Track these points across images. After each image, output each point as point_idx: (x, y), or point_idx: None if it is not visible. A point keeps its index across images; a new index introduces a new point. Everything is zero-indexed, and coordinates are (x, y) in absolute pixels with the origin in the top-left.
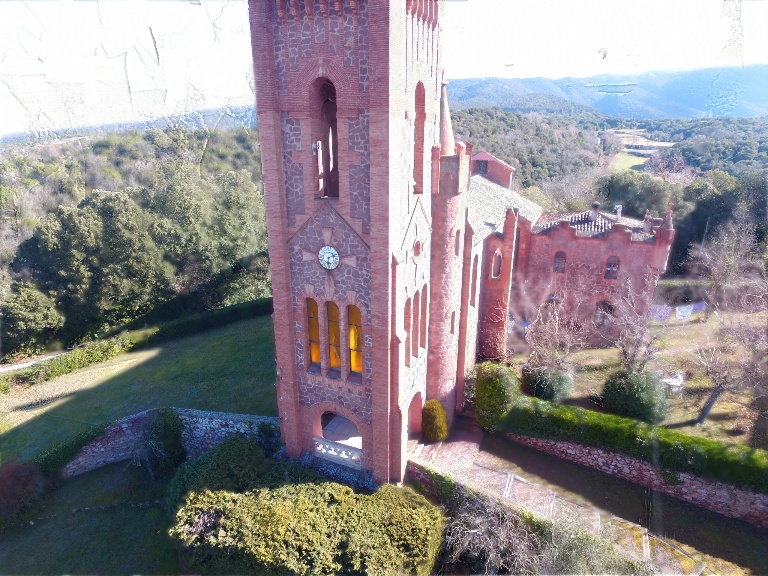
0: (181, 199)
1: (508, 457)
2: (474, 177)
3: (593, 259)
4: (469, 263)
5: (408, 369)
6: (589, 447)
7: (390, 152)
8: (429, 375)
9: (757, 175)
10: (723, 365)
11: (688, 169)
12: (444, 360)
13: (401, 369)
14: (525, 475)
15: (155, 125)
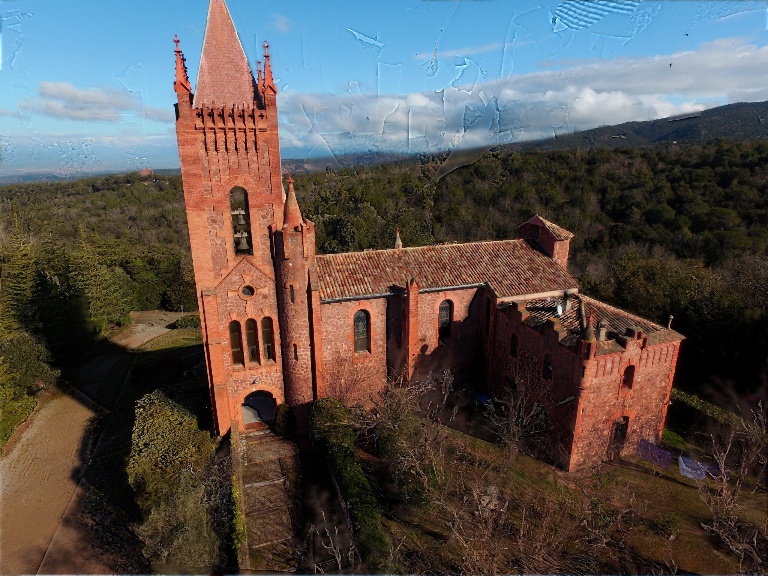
0: (346, 228)
1: (305, 470)
2: None
3: (535, 352)
4: (312, 312)
5: (243, 368)
6: (342, 495)
7: (190, 231)
8: (286, 385)
9: None
10: (618, 537)
11: None
12: (292, 378)
13: (216, 362)
14: (295, 485)
15: (406, 165)
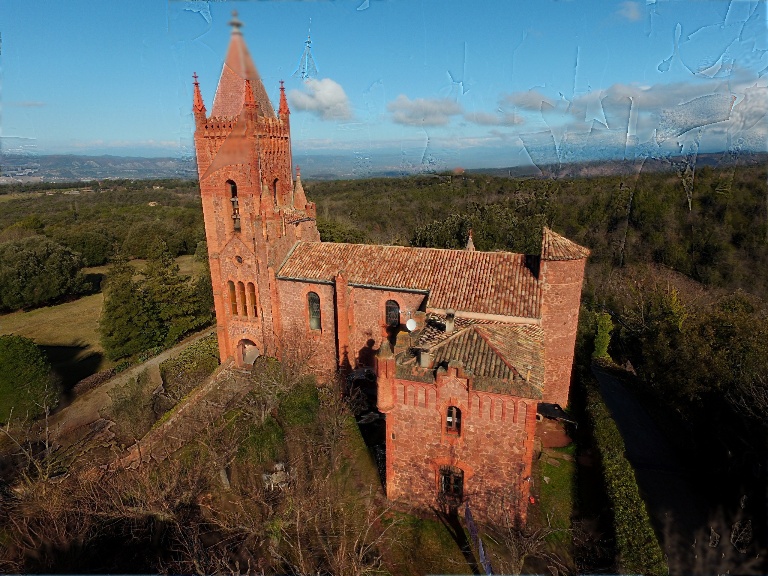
0: None
1: None
2: (498, 253)
3: None
4: None
5: (237, 319)
6: None
7: (204, 210)
8: None
9: None
10: (333, 563)
11: None
12: None
13: (218, 308)
14: None
15: (602, 167)
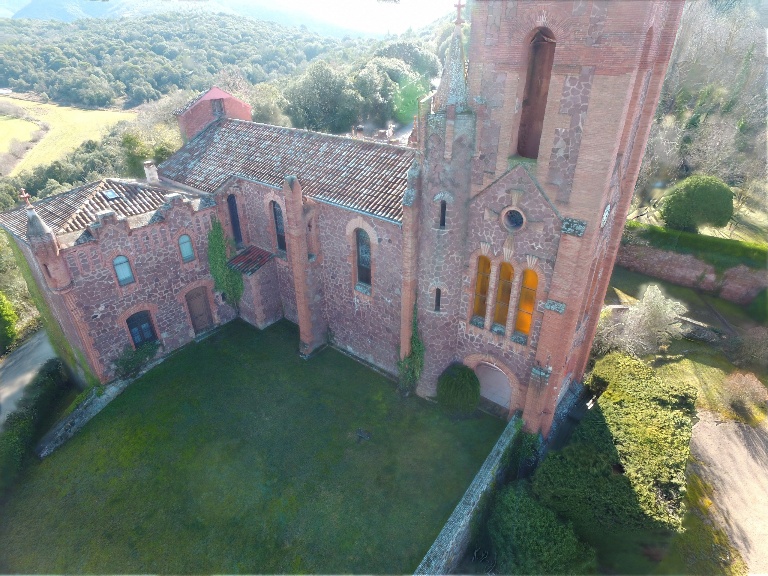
0: None
1: None
2: None
3: None
4: None
5: None
6: None
7: None
8: None
9: (300, 86)
10: None
11: (246, 85)
12: None
13: None
14: None
15: None
